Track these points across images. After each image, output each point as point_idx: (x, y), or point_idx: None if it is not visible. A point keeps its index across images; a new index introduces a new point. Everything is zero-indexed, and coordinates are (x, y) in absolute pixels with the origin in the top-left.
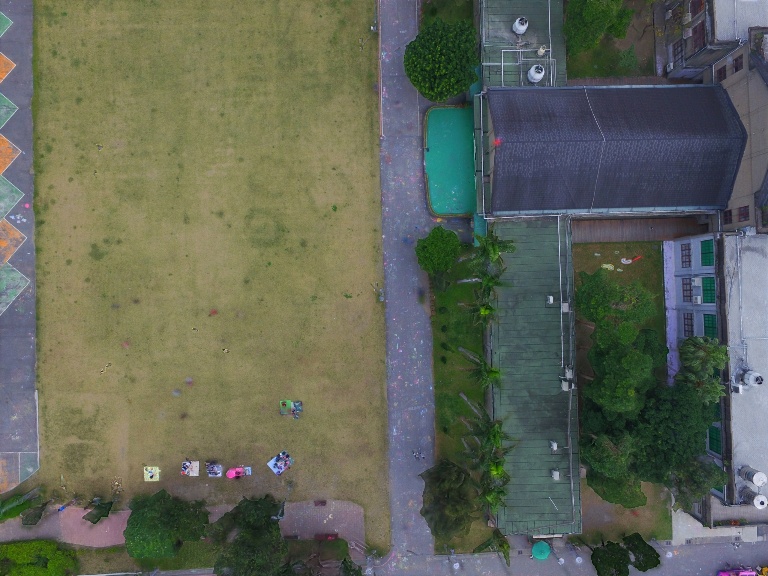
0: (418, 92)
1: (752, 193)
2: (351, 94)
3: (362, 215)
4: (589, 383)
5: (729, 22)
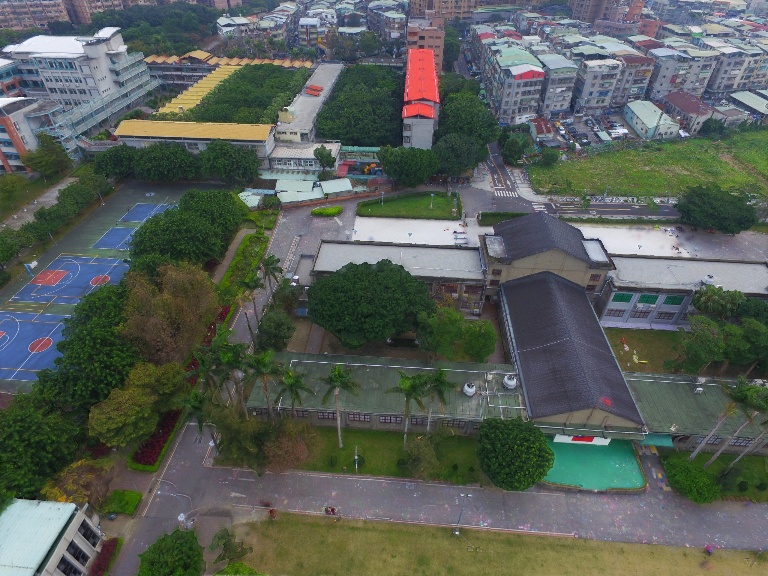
0: (519, 492)
1: (585, 271)
2: (534, 568)
3: (673, 569)
4: (759, 368)
5: (470, 274)
